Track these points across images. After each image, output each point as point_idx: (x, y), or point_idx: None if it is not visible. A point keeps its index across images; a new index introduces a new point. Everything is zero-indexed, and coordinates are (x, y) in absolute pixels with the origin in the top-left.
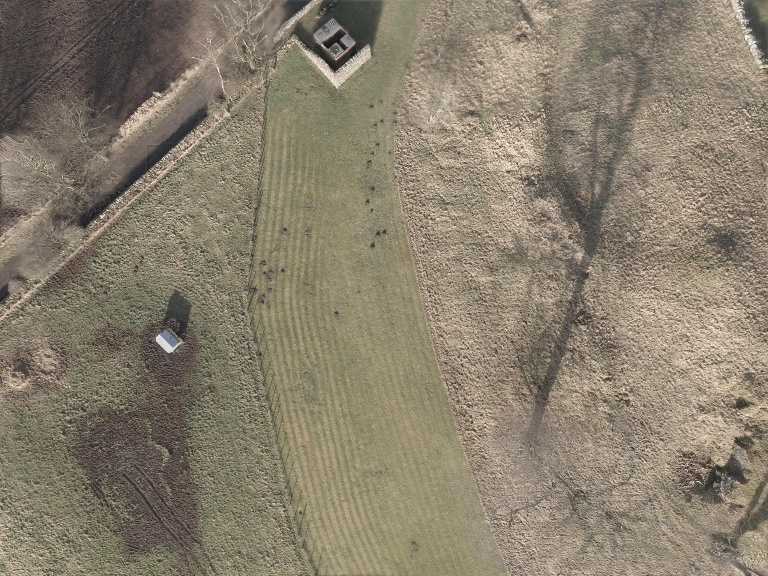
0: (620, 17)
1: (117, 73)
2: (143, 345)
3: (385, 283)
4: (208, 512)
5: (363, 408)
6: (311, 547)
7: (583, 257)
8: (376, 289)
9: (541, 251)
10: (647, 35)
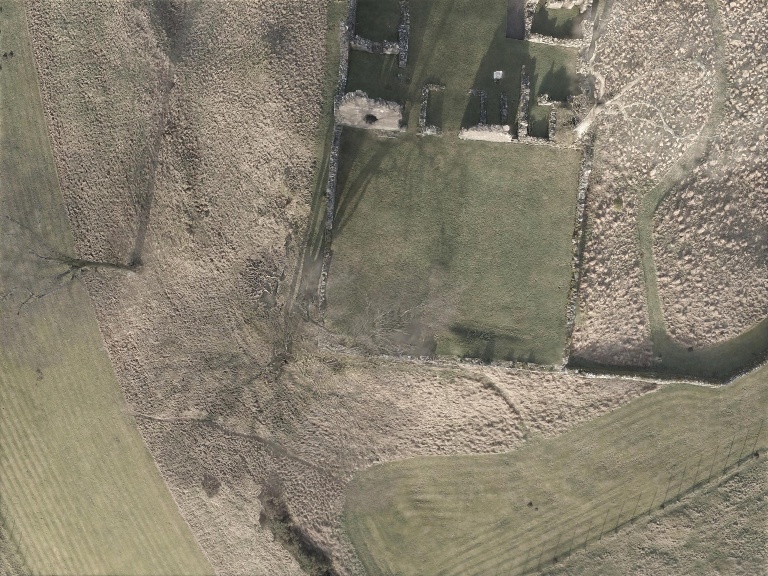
0: None
1: None
2: None
3: (11, 106)
4: None
5: None
6: None
7: (169, 66)
8: (2, 112)
9: (138, 64)
10: None
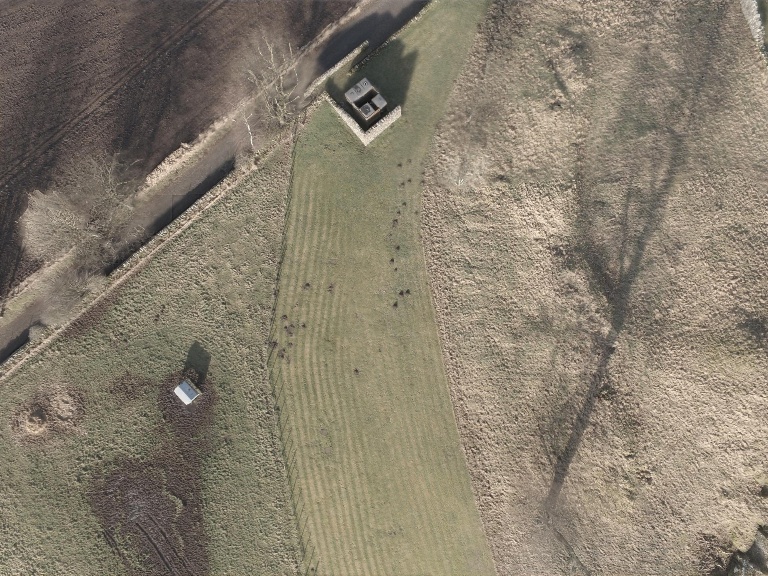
0: (656, 91)
1: (146, 122)
2: (161, 395)
3: (406, 343)
4: (220, 565)
5: (379, 468)
6: None
7: (610, 331)
8: (397, 349)
9: (567, 322)
10: (683, 112)
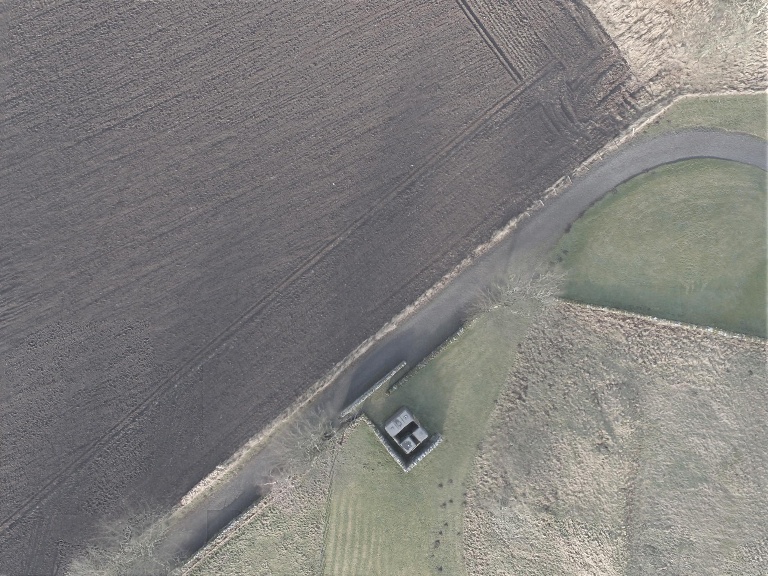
0: (707, 442)
1: (179, 439)
2: None
3: None
4: None
5: None
6: None
7: None
8: None
9: None
10: (737, 472)
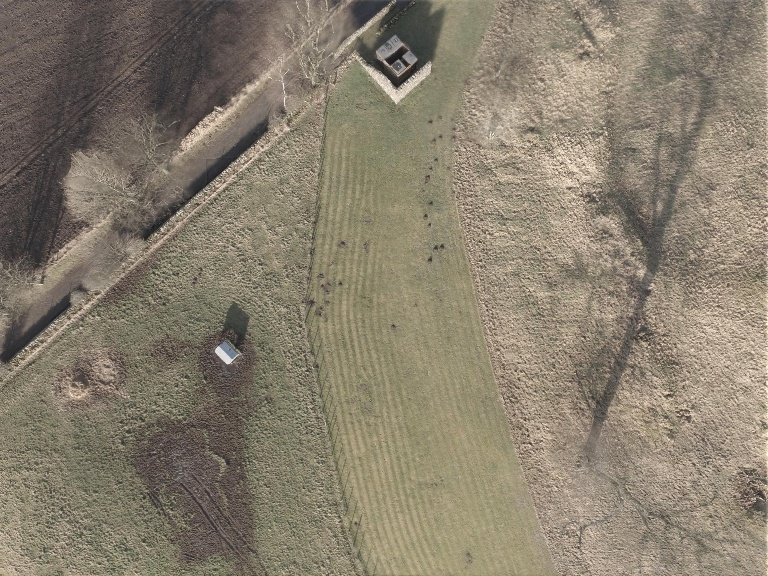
0: (684, 37)
1: (178, 87)
2: (201, 356)
3: (442, 297)
4: (264, 522)
5: (419, 420)
6: (366, 558)
7: (645, 274)
8: (433, 303)
9: (602, 267)
10: (712, 55)
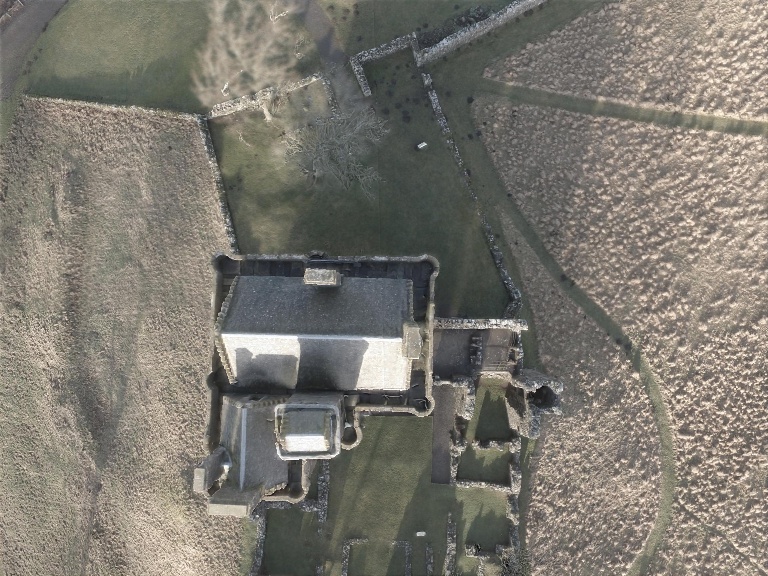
0: (132, 221)
1: None
2: None
3: None
4: None
5: None
6: None
7: (96, 469)
8: None
9: (67, 456)
10: (147, 246)
